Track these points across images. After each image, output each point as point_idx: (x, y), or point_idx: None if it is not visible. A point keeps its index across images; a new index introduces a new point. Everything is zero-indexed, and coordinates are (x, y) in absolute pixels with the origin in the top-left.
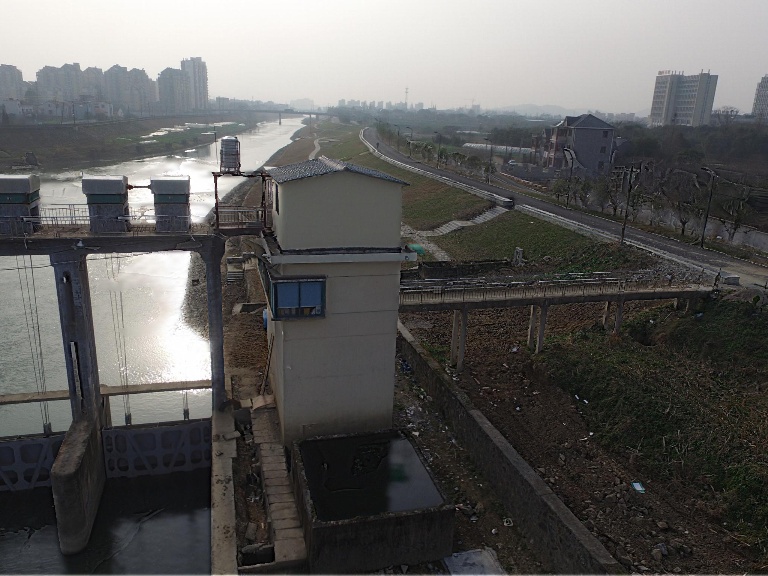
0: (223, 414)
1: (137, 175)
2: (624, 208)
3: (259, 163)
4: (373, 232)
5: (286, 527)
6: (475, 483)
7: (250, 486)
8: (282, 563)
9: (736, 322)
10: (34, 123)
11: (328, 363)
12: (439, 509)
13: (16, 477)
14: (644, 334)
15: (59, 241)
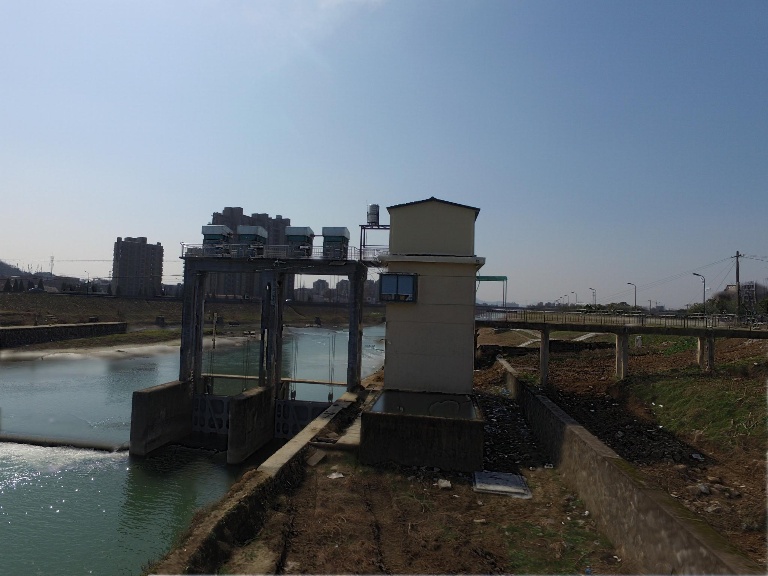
0: (351, 394)
1: (376, 329)
2: (763, 320)
3: None
4: (453, 245)
5: (355, 433)
6: (530, 445)
7: (349, 425)
8: (340, 445)
9: None
10: (323, 301)
11: (418, 343)
12: (468, 419)
13: (222, 424)
14: (746, 374)
15: (267, 262)
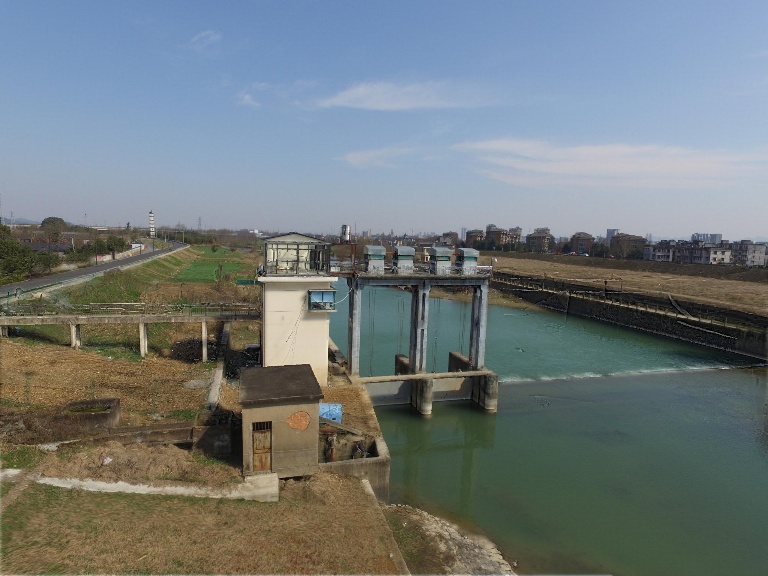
0: None
1: None
2: None
3: None
4: None
5: None
6: None
7: None
8: None
9: None
10: None
11: None
12: None
13: None
14: None
15: None
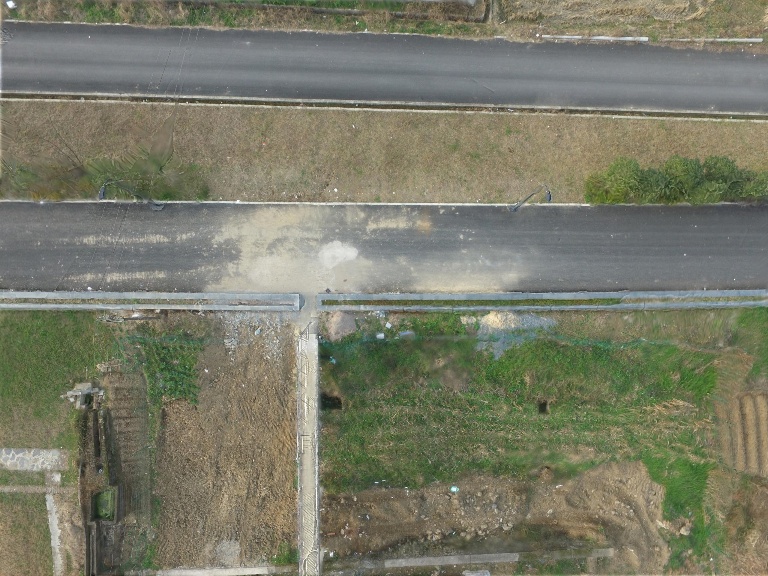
0: None
1: None
2: None
3: None
4: None
5: None
6: None
7: None
8: None
9: (363, 356)
10: None
11: None
12: None
13: None
14: None
15: None
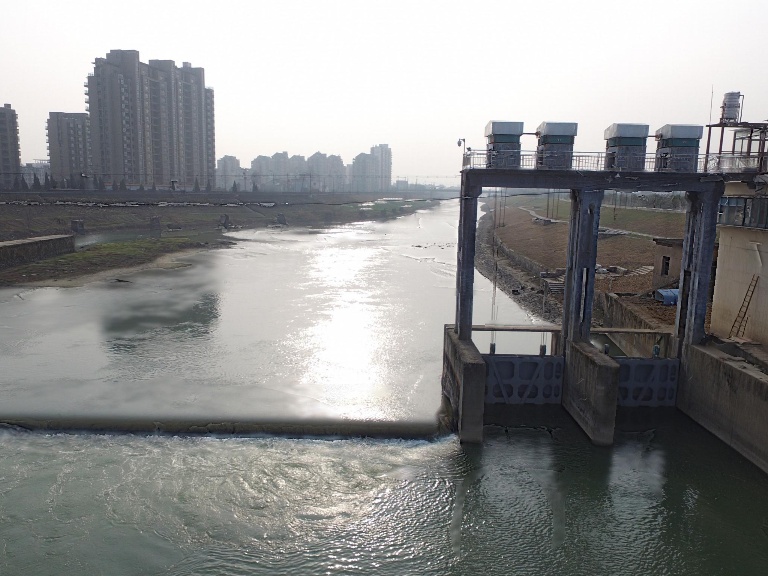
0: (706, 347)
1: (377, 230)
2: None
3: (482, 222)
4: None
5: None
6: None
7: None
8: None
9: None
10: (281, 191)
11: None
12: None
13: (511, 391)
14: None
15: (594, 176)
